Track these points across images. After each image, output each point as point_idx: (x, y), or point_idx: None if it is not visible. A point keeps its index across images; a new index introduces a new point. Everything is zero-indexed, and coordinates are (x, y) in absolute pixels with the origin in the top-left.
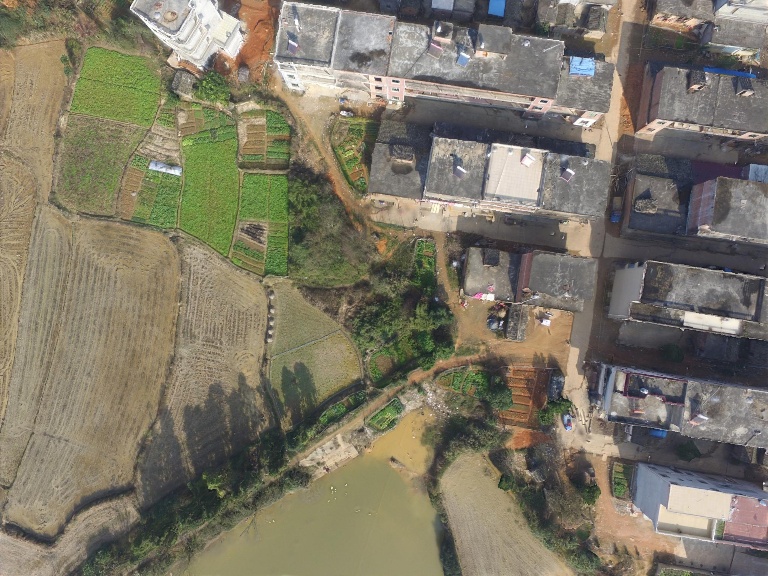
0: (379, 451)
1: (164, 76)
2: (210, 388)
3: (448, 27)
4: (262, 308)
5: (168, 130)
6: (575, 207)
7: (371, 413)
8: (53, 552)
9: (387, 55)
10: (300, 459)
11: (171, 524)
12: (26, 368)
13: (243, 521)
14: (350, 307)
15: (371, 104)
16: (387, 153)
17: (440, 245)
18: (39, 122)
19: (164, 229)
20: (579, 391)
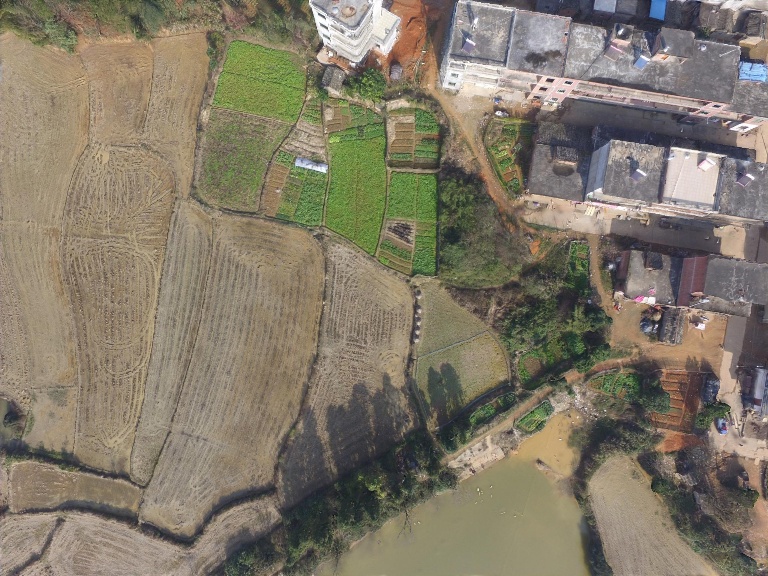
0: (525, 453)
1: (311, 72)
2: (354, 388)
3: (629, 29)
4: (407, 308)
5: (314, 126)
6: (751, 212)
7: (521, 415)
8: (191, 553)
9: (563, 56)
10: (449, 460)
11: (327, 525)
12: (163, 366)
13: (387, 522)
14: (499, 308)
15: (526, 105)
16: (548, 154)
17: (594, 247)
18: (178, 115)
19: (309, 227)
20: (732, 395)
